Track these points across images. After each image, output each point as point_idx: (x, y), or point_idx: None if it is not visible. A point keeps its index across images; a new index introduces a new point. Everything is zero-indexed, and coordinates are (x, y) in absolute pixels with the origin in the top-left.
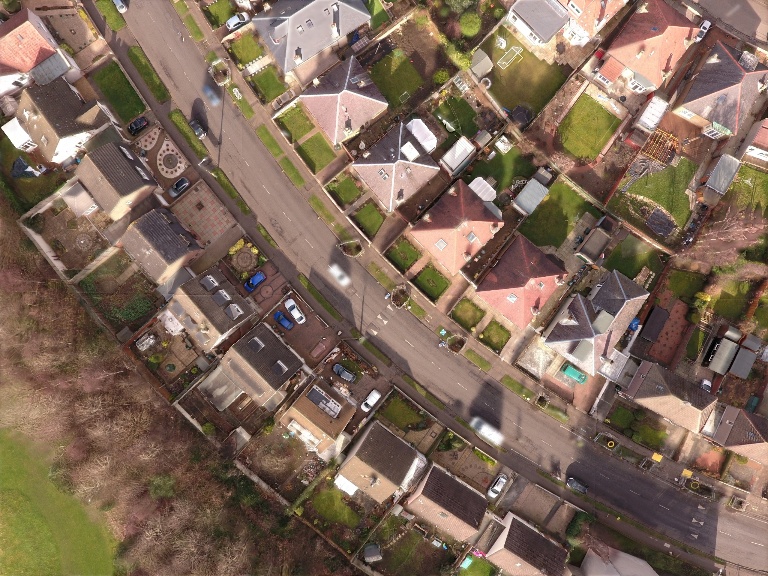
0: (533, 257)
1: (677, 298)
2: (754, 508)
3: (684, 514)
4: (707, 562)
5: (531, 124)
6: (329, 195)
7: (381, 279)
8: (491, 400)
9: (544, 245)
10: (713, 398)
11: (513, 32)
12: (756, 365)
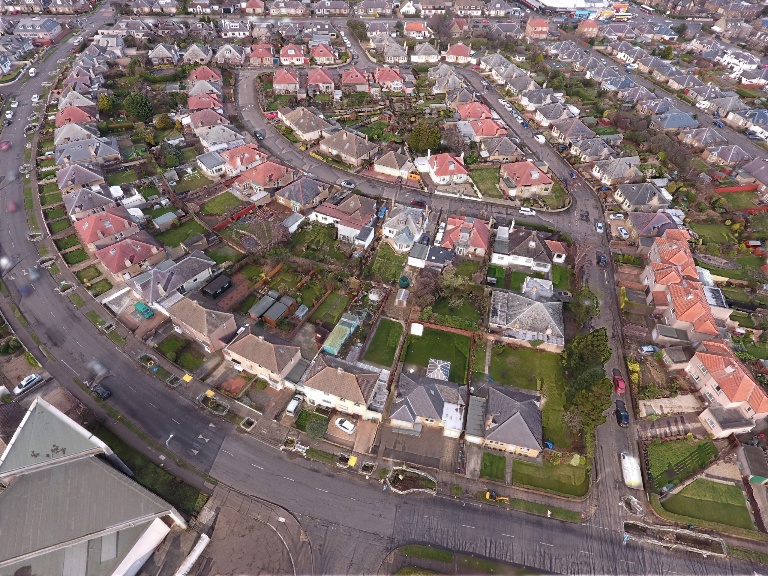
0: (142, 236)
1: (247, 279)
2: (264, 431)
3: (193, 430)
4: (197, 479)
5: (187, 197)
6: (42, 213)
7: (42, 252)
8: (69, 325)
9: (166, 246)
10: (227, 312)
11: (200, 170)
12: (294, 321)
